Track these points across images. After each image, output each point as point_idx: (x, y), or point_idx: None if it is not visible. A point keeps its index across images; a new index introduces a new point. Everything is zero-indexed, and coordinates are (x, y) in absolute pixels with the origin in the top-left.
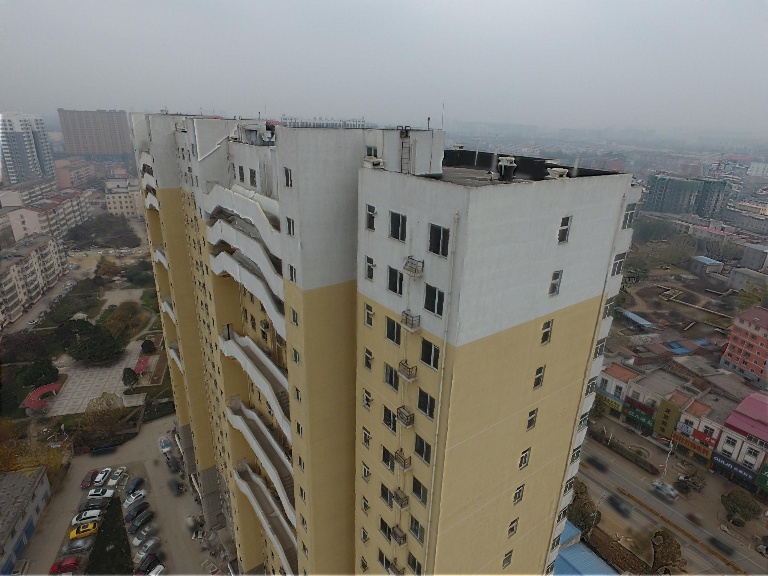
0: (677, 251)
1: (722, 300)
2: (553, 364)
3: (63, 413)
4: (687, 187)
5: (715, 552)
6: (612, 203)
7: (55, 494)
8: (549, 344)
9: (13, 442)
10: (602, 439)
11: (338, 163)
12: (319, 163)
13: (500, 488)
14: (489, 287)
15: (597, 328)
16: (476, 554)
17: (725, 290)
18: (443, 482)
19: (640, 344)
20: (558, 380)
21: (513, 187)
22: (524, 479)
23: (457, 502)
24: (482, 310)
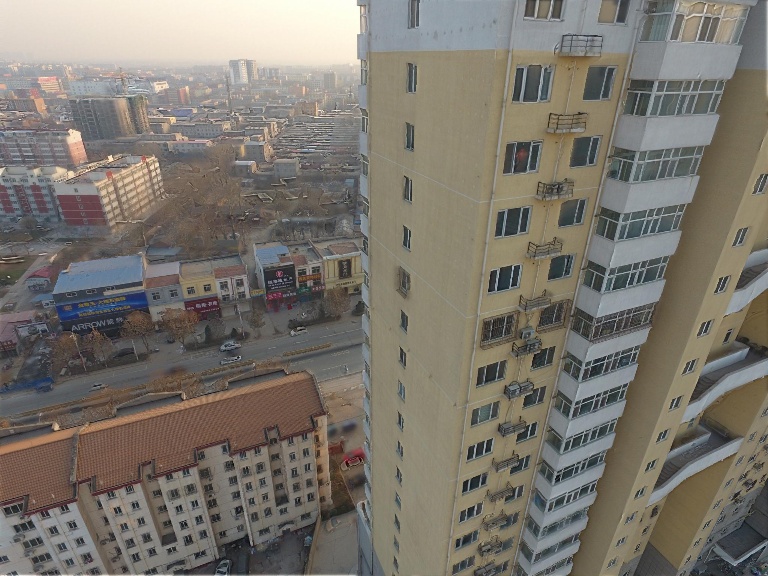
0: (227, 161)
1: (294, 187)
2: None
3: None
4: (119, 106)
5: None
6: None
7: None
8: None
9: None
10: None
11: None
12: None
13: None
14: None
15: None
16: None
17: (278, 181)
18: None
19: (352, 231)
20: None
21: None
22: None
23: None
24: None
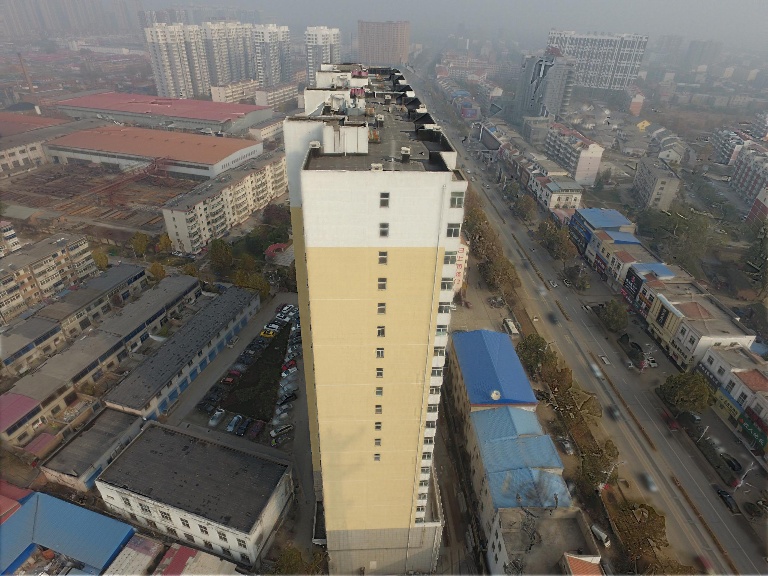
0: None
1: None
2: (394, 280)
3: (283, 264)
4: None
5: (735, 568)
6: (431, 189)
7: (262, 309)
8: (386, 266)
9: (253, 273)
10: (695, 435)
11: (309, 141)
12: (297, 140)
13: (360, 341)
14: (325, 221)
15: (436, 268)
16: (348, 373)
17: None
18: (311, 316)
19: None
20: (403, 292)
21: (332, 172)
22: (383, 345)
23: (325, 333)
24: (322, 232)
